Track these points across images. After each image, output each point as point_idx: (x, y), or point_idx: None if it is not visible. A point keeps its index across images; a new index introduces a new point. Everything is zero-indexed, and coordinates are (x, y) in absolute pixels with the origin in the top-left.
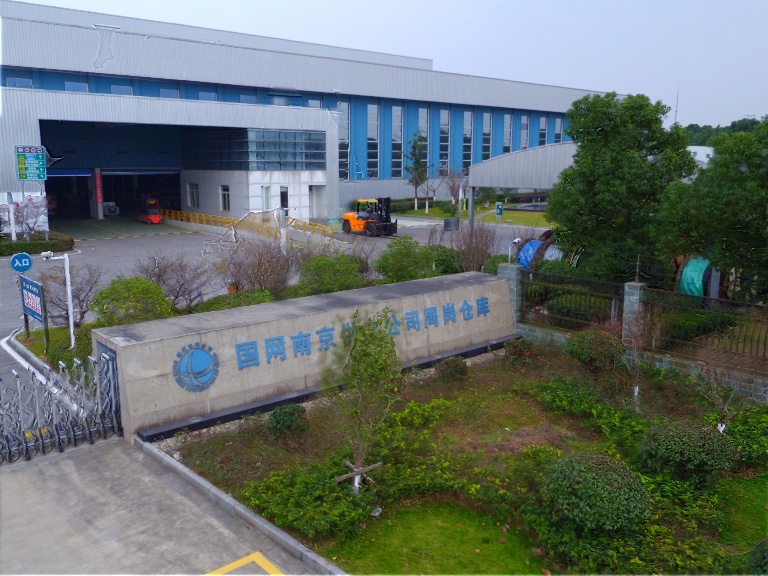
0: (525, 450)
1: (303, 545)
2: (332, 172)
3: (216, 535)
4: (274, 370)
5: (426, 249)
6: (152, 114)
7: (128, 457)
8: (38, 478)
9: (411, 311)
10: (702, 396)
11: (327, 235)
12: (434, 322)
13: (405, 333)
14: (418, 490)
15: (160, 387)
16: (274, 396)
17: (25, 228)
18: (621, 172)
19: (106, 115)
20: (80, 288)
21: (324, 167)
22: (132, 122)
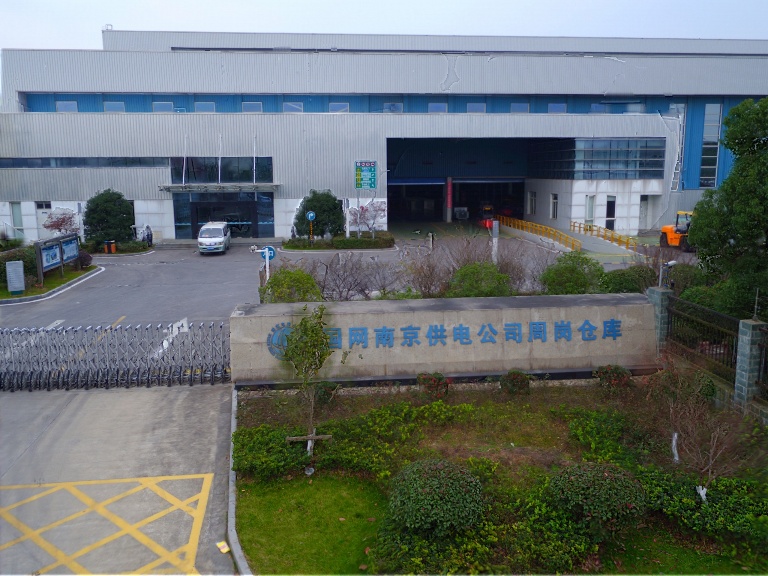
0: (470, 459)
1: (235, 476)
2: (671, 181)
3: (204, 456)
4: (355, 355)
5: (599, 266)
6: (482, 129)
7: (220, 397)
8: (161, 398)
9: (512, 323)
10: (765, 462)
11: (630, 247)
12: (541, 337)
13: (502, 343)
14: (350, 465)
15: (256, 352)
16: (353, 377)
17: (361, 228)
18: (764, 190)
19: (441, 132)
20: None
21: (661, 176)
22: (463, 137)
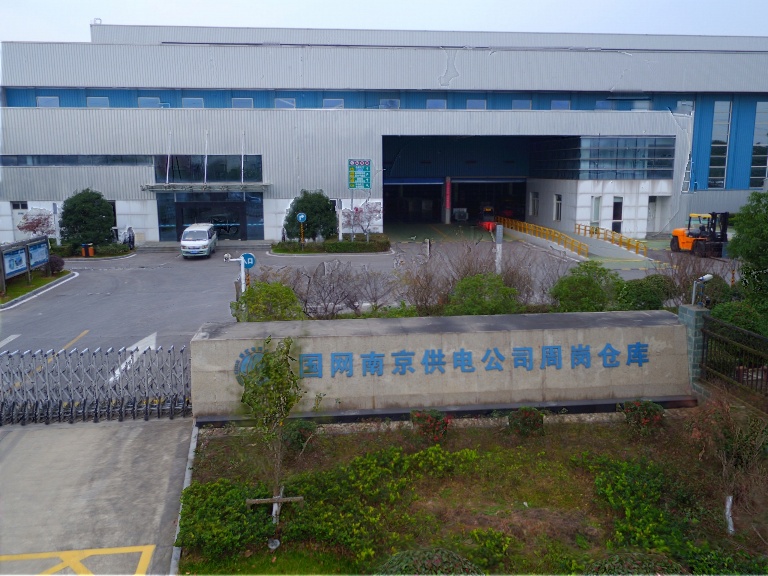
0: (475, 531)
1: (180, 552)
2: (680, 181)
3: (147, 520)
4: (338, 385)
5: (618, 278)
6: (482, 126)
7: (178, 436)
8: (108, 436)
9: (522, 347)
10: None
11: (640, 252)
12: (556, 363)
13: (510, 370)
14: (324, 537)
15: (221, 381)
16: (335, 410)
17: (355, 230)
18: None
19: (440, 129)
20: (289, 286)
21: (671, 176)
22: (463, 134)
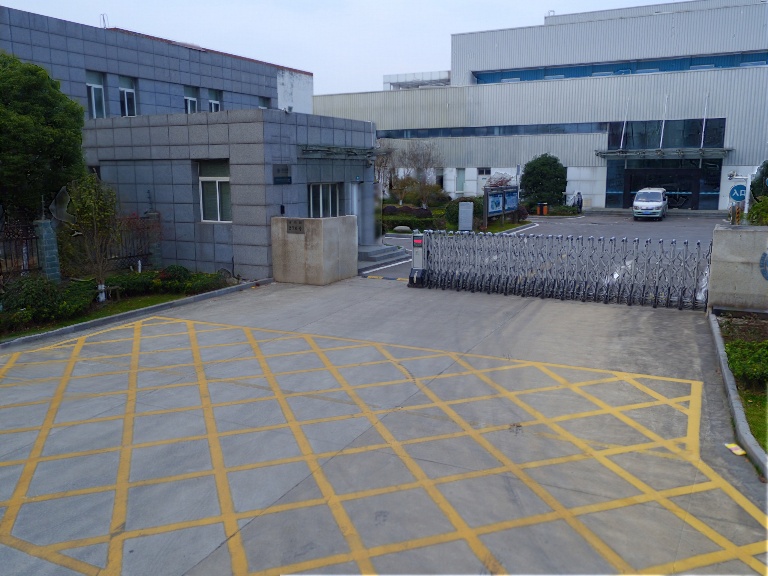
0: None
1: (736, 386)
2: None
3: (687, 366)
4: None
5: None
6: None
7: (693, 320)
8: (622, 313)
9: None
10: None
11: None
12: None
13: None
14: None
15: (743, 273)
16: None
17: None
18: None
19: None
20: None
21: None
22: None
